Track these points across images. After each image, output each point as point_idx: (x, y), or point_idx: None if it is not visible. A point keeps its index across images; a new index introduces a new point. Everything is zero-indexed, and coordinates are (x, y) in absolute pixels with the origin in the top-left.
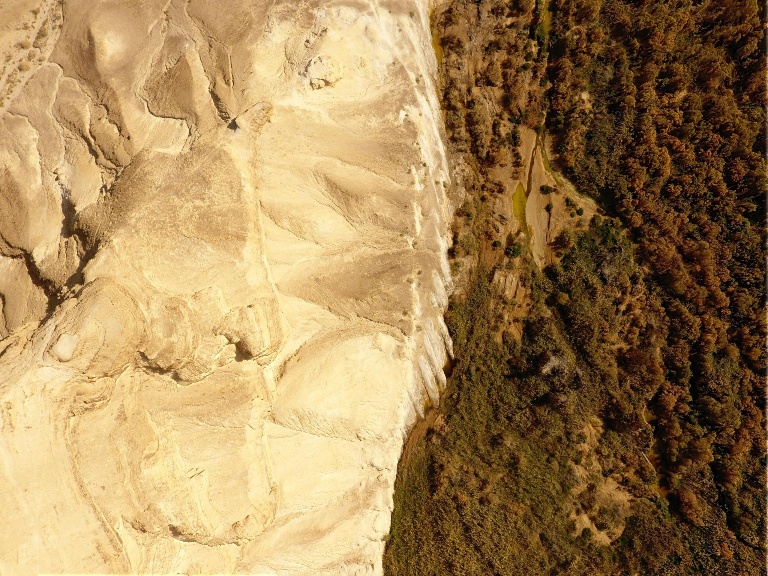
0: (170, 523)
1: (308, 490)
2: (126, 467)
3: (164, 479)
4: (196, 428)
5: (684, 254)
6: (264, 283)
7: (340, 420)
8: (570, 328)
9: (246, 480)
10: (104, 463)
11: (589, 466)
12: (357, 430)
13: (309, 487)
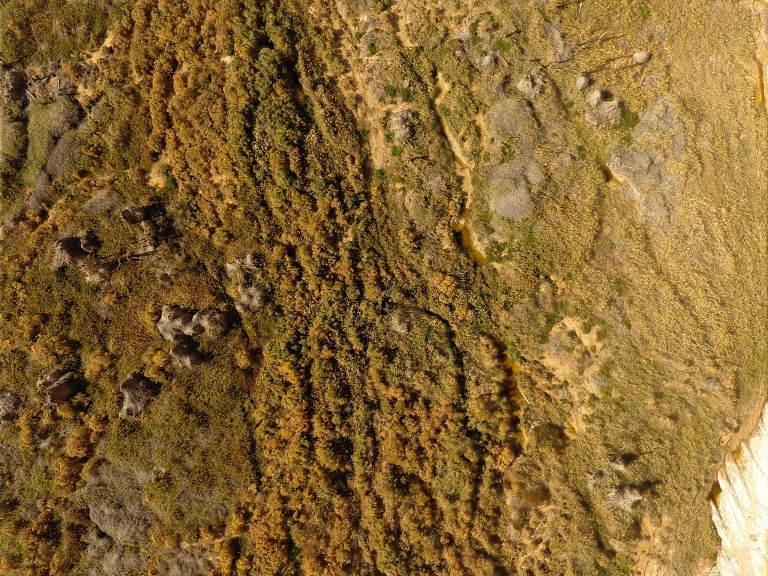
0: None
1: None
2: None
3: None
4: None
5: None
6: None
7: None
8: (596, 529)
9: None
10: None
11: (582, 393)
12: None
13: None
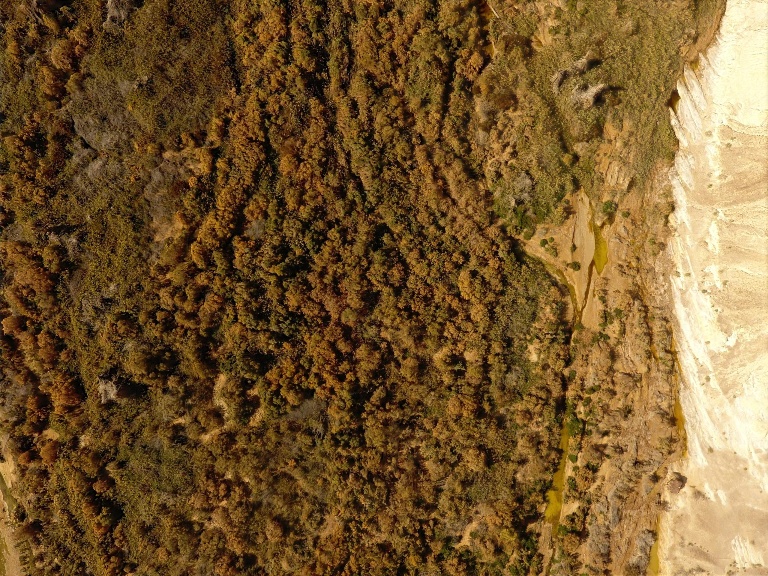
0: None
1: None
2: None
3: None
4: None
5: (449, 197)
6: None
7: None
8: (560, 132)
9: None
10: None
11: (549, 5)
12: None
13: None
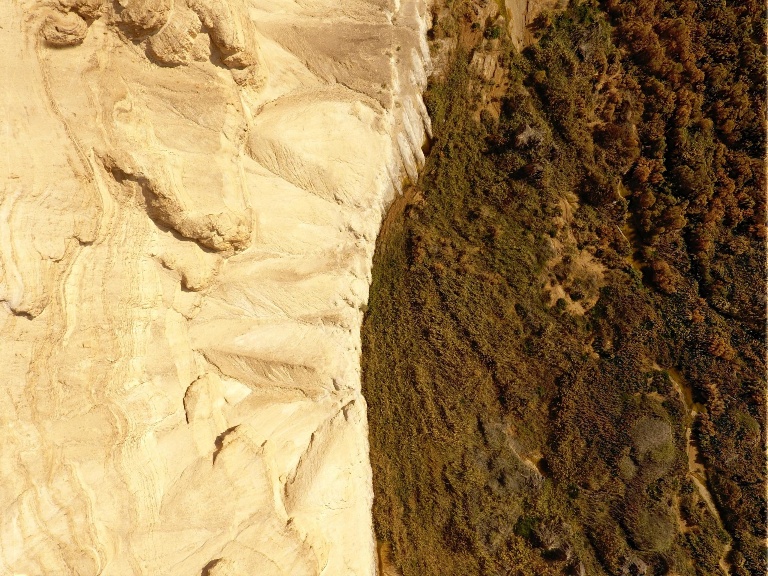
0: (142, 171)
1: (285, 230)
2: (98, 106)
3: (137, 139)
4: (170, 115)
5: (660, 33)
6: (240, 3)
7: (317, 169)
8: (547, 106)
9: (221, 182)
10: (76, 94)
11: (564, 238)
12: (335, 189)
13: (286, 228)
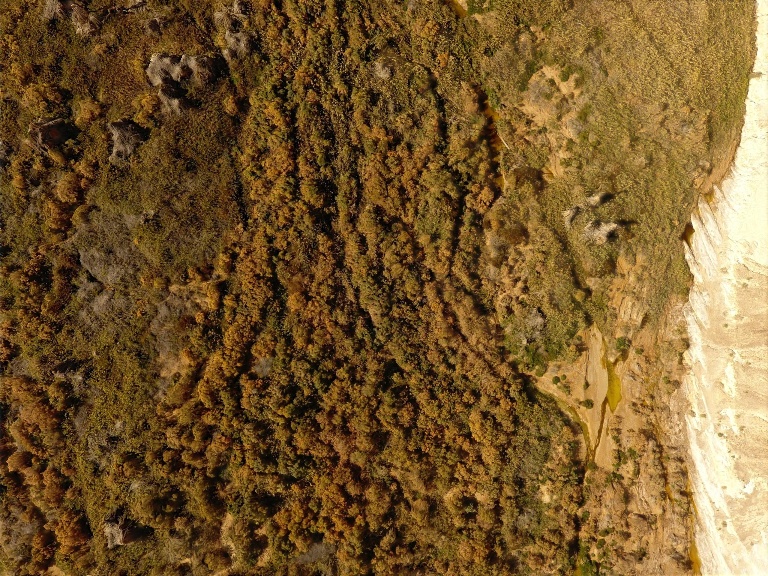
0: None
1: None
2: None
3: None
4: None
5: (460, 334)
6: None
7: None
8: (572, 266)
9: None
10: None
11: (560, 137)
12: None
13: None
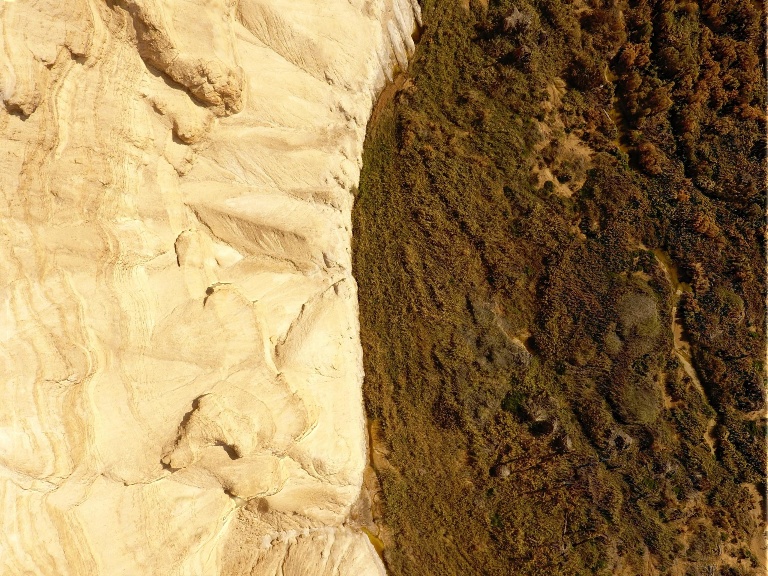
0: None
1: (275, 99)
2: None
3: None
4: None
5: None
6: None
7: (307, 43)
8: None
9: (211, 33)
10: None
11: (552, 122)
12: (325, 67)
13: (276, 97)
